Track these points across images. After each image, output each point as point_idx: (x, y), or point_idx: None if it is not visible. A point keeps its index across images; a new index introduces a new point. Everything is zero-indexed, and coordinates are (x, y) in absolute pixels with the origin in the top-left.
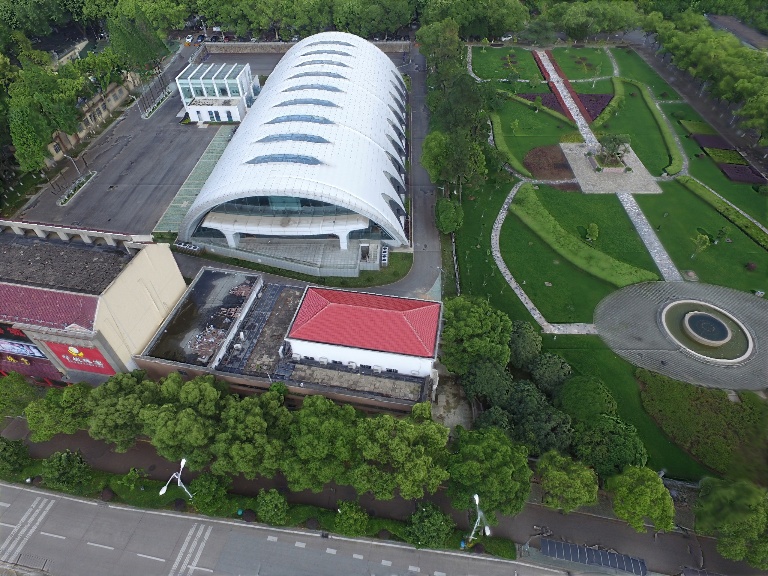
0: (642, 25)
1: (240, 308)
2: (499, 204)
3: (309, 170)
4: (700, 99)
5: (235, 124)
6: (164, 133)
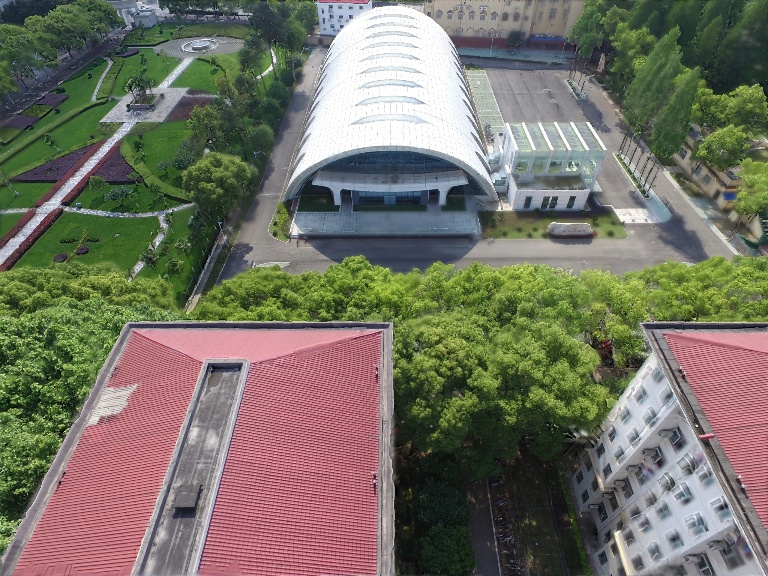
0: None
1: None
2: None
3: None
4: None
5: None
6: None
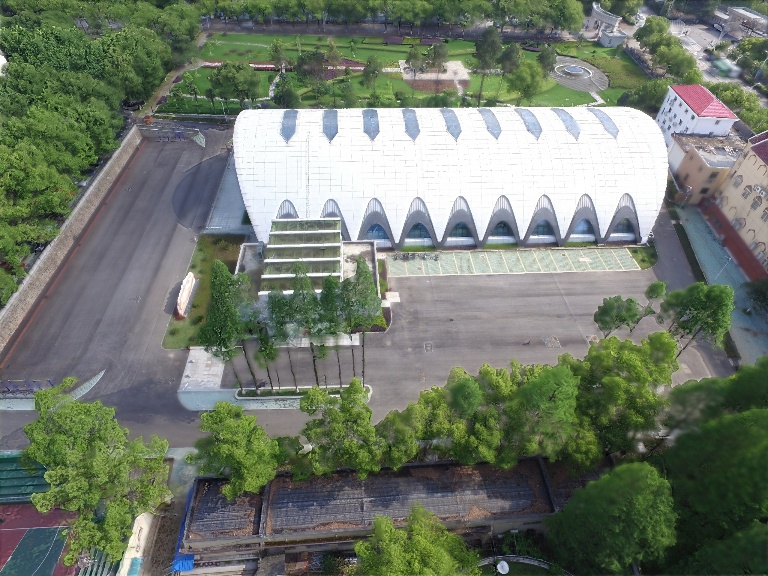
0: (206, 11)
1: (725, 147)
2: (497, 105)
3: (606, 109)
4: (328, 32)
5: (384, 262)
6: (425, 339)
